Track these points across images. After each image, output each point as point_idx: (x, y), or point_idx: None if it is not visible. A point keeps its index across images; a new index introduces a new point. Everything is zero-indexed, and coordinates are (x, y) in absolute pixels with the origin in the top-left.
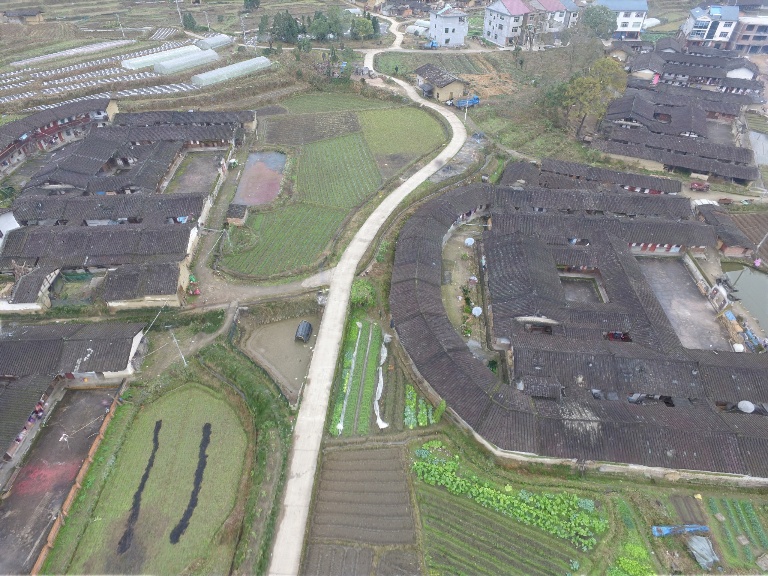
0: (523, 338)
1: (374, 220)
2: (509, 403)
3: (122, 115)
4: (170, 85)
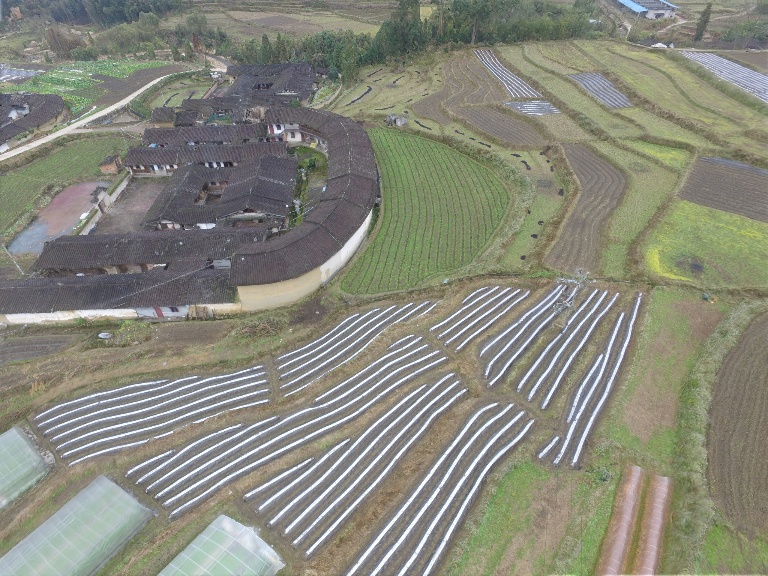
0: (1, 114)
1: (2, 157)
2: (39, 96)
3: (228, 275)
4: (122, 445)
